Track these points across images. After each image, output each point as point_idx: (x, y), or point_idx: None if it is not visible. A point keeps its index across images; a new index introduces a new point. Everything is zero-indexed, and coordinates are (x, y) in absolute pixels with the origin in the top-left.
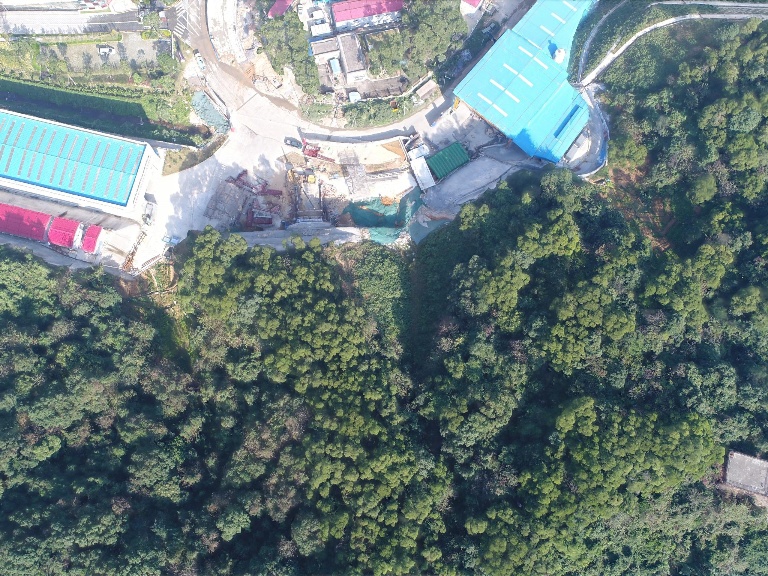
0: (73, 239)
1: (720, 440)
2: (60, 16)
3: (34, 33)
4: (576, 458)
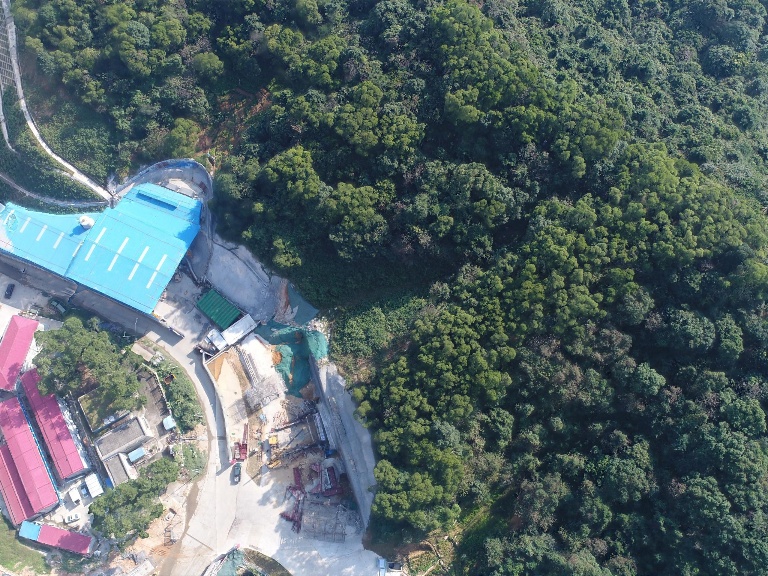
0: None
1: (442, 2)
2: None
3: None
4: (500, 98)
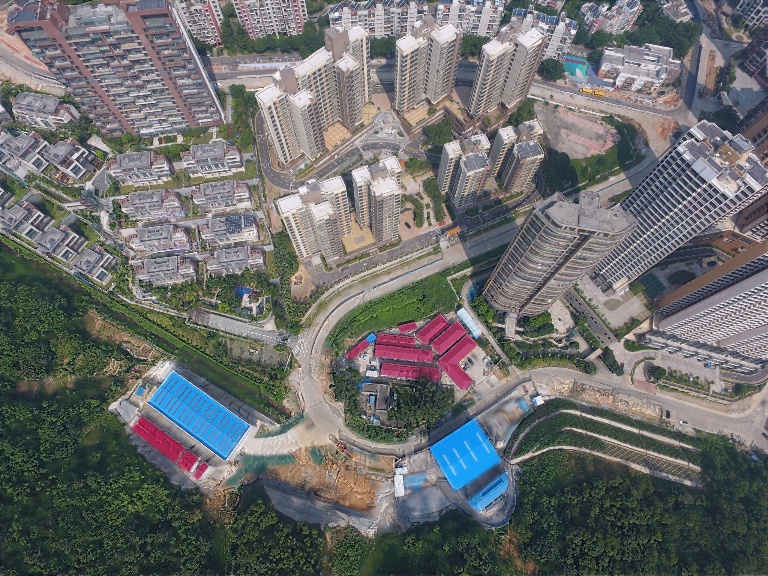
0: (191, 468)
1: None
2: (237, 323)
3: (220, 329)
4: None
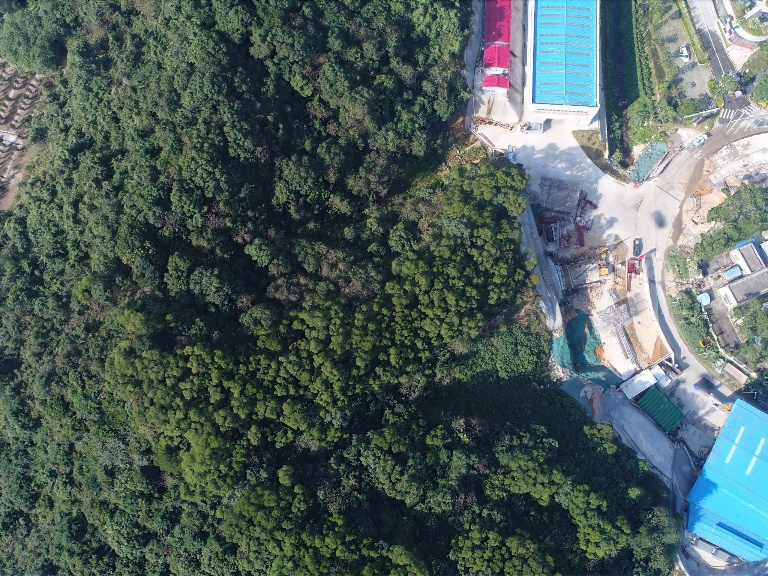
0: (492, 66)
1: None
2: (709, 5)
3: None
4: (365, 569)
